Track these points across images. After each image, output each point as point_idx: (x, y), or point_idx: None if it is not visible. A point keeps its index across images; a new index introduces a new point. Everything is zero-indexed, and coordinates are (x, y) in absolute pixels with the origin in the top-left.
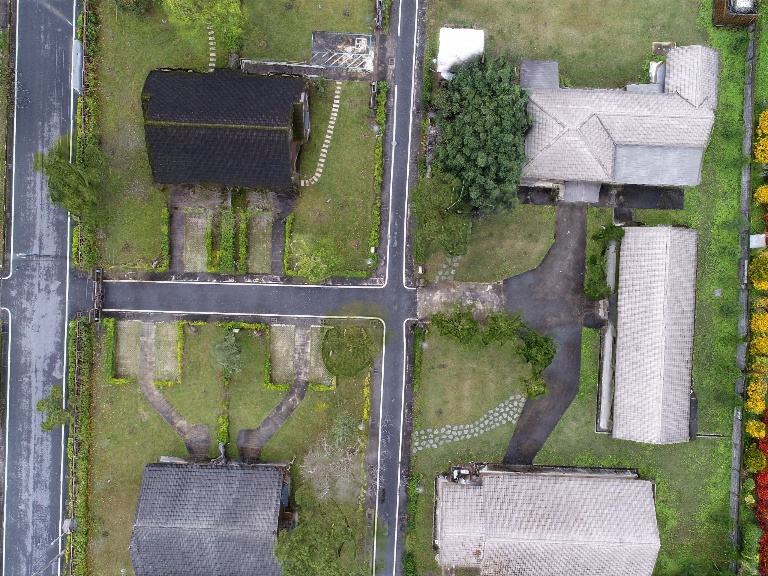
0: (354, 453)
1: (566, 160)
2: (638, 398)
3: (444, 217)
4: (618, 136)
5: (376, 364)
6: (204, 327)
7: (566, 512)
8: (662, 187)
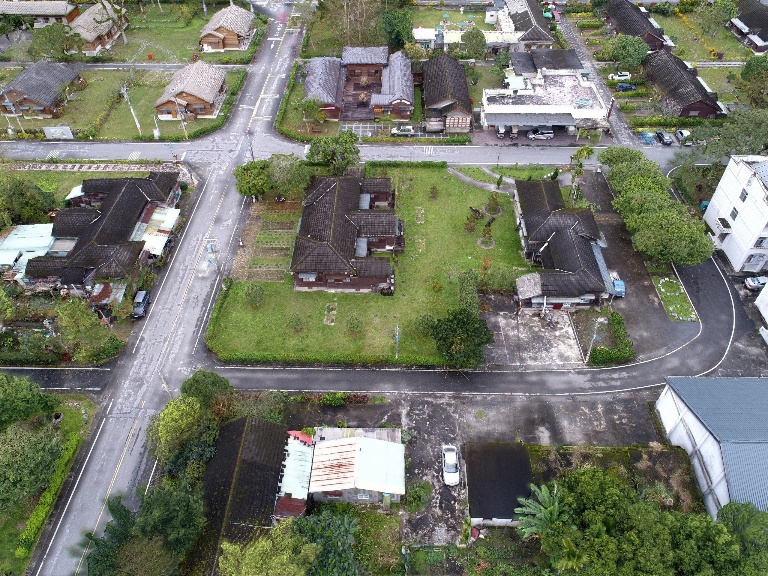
0: None
1: None
2: (50, 8)
3: None
4: None
5: (3, 68)
6: None
7: None
8: None
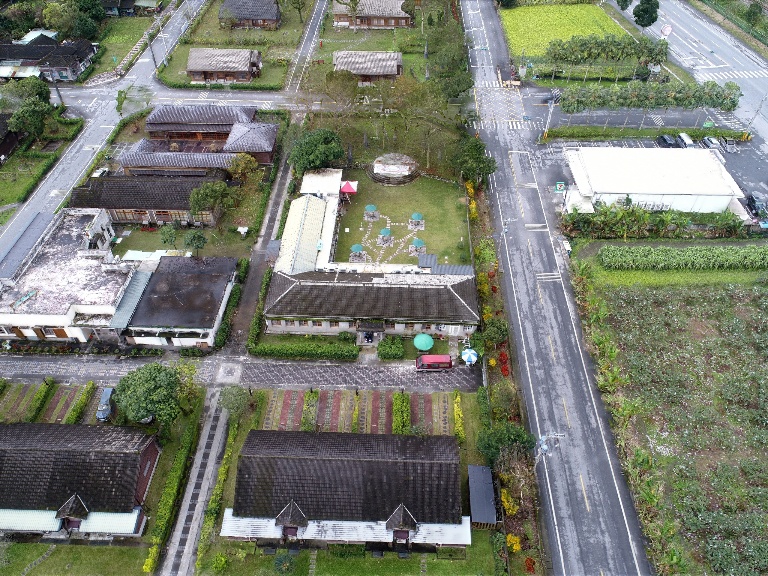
0: (305, 11)
1: None
2: None
3: None
4: None
5: None
6: None
7: None
8: None
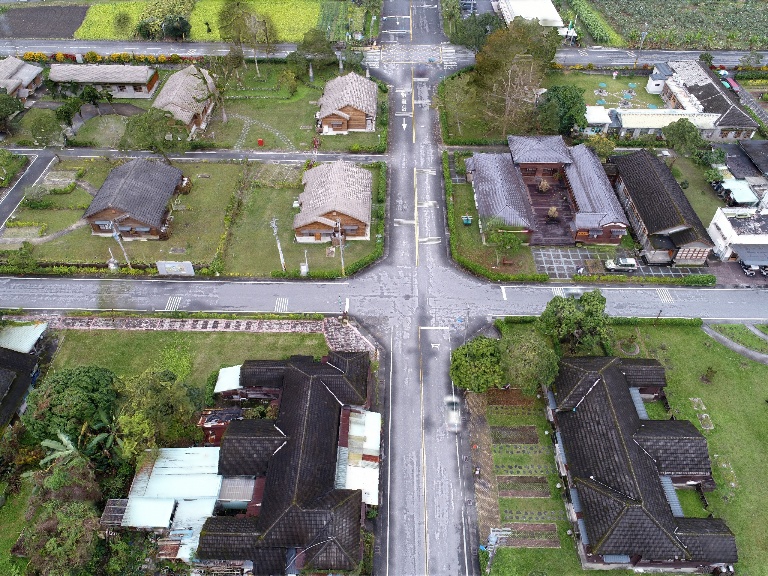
0: None
1: (1, 87)
2: (127, 74)
3: (3, 117)
4: (2, 78)
5: None
6: (17, 218)
7: (171, 88)
8: (42, 83)
